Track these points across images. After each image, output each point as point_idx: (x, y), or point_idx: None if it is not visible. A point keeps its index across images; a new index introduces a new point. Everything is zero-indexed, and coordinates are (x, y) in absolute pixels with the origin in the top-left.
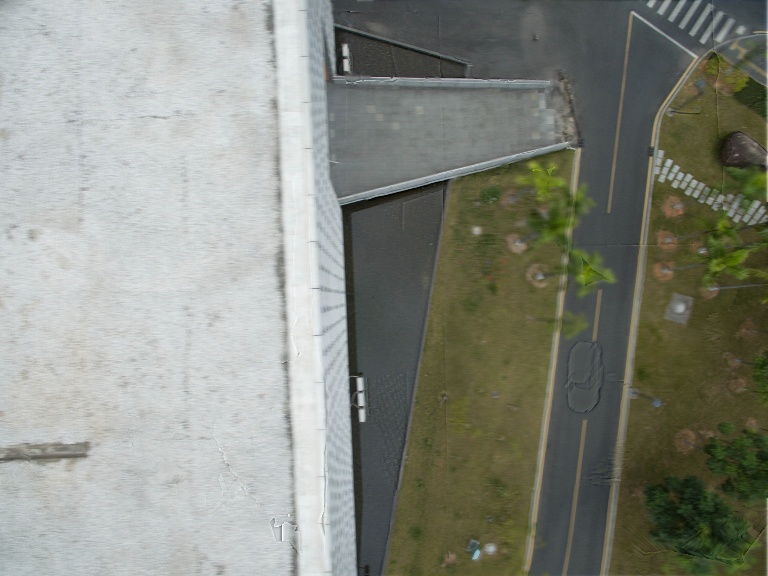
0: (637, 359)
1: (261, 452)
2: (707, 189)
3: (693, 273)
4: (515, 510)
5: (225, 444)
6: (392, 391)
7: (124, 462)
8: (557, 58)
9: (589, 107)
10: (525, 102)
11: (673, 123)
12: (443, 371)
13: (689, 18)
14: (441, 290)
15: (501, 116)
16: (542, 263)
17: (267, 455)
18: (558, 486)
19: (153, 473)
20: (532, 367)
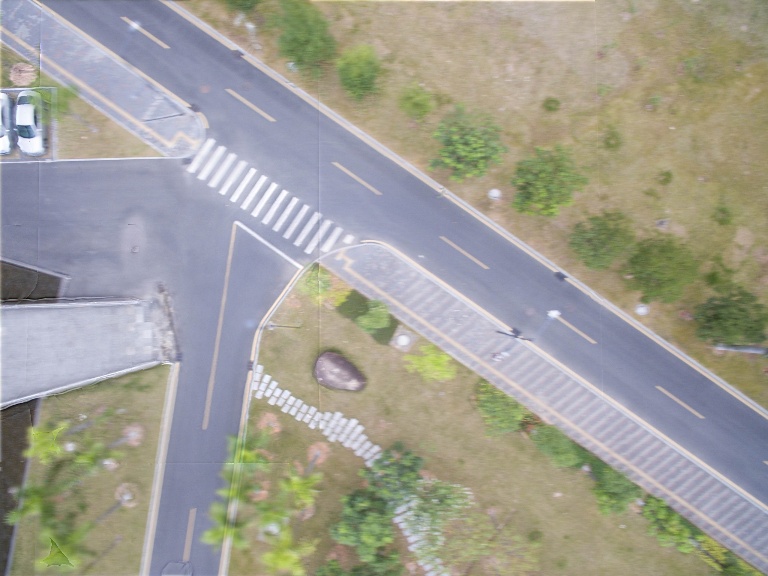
0: None
1: None
2: (305, 406)
3: (288, 493)
4: None
5: None
6: None
7: None
8: (157, 270)
9: (188, 320)
10: (120, 317)
11: (273, 337)
12: None
13: (294, 227)
14: (32, 508)
15: (93, 333)
16: (132, 482)
17: None
18: None
19: None
20: None
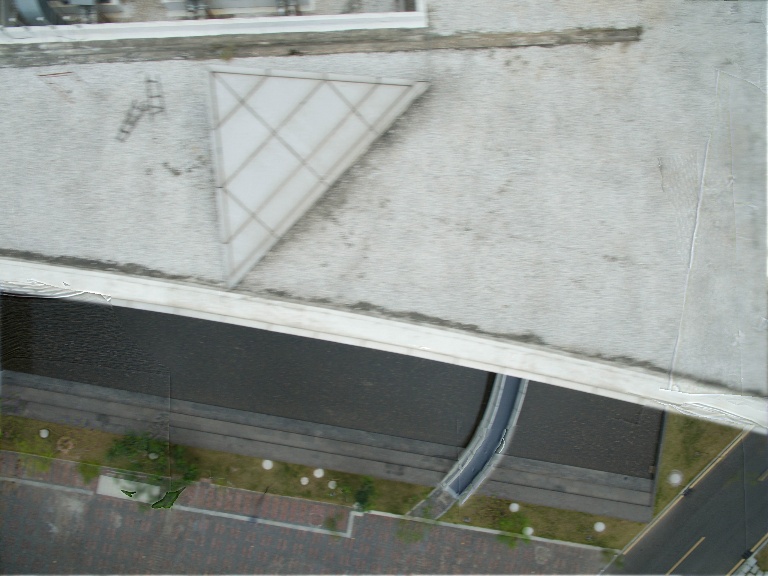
0: None
1: None
2: None
3: None
4: None
5: None
6: (684, 171)
7: (683, 39)
8: None
9: None
10: None
11: None
12: (729, 155)
13: None
14: (726, 76)
15: None
16: None
17: None
18: None
19: (700, 58)
20: None
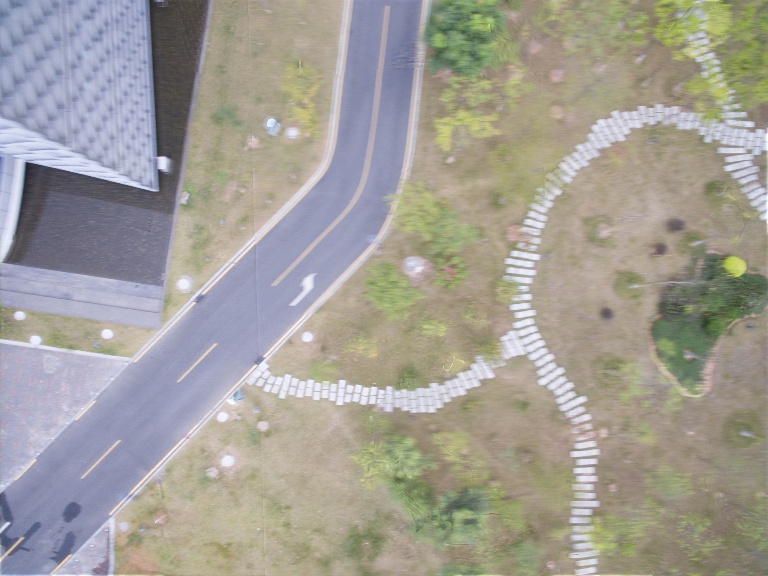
0: None
1: None
2: None
3: None
4: (318, 93)
5: None
6: None
7: None
8: None
9: None
10: None
11: None
12: None
13: None
14: None
15: None
16: None
17: None
18: (361, 70)
19: None
20: None
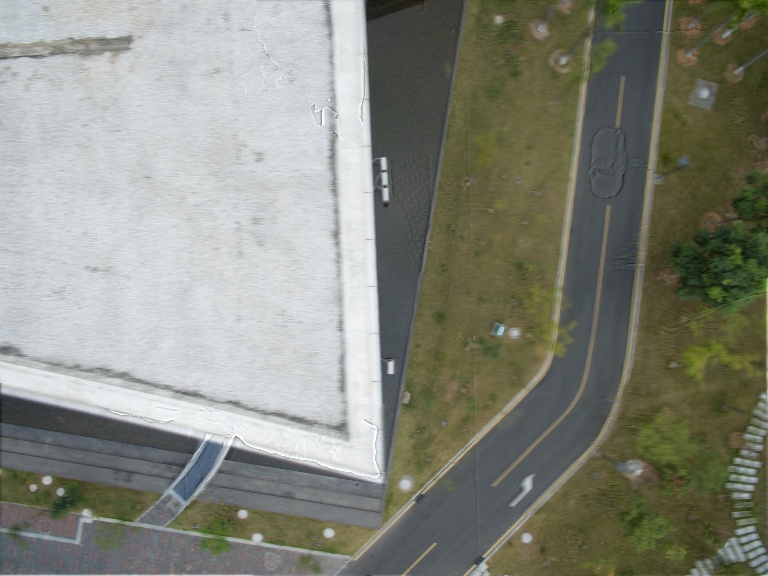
0: (661, 145)
1: (301, 43)
2: None
3: (717, 59)
4: (539, 294)
5: (265, 36)
6: (415, 174)
7: (167, 49)
8: None
9: None
10: None
11: None
12: (466, 157)
13: None
14: (463, 77)
15: None
16: (564, 49)
17: (307, 45)
18: (582, 271)
19: (194, 68)
20: (555, 152)
